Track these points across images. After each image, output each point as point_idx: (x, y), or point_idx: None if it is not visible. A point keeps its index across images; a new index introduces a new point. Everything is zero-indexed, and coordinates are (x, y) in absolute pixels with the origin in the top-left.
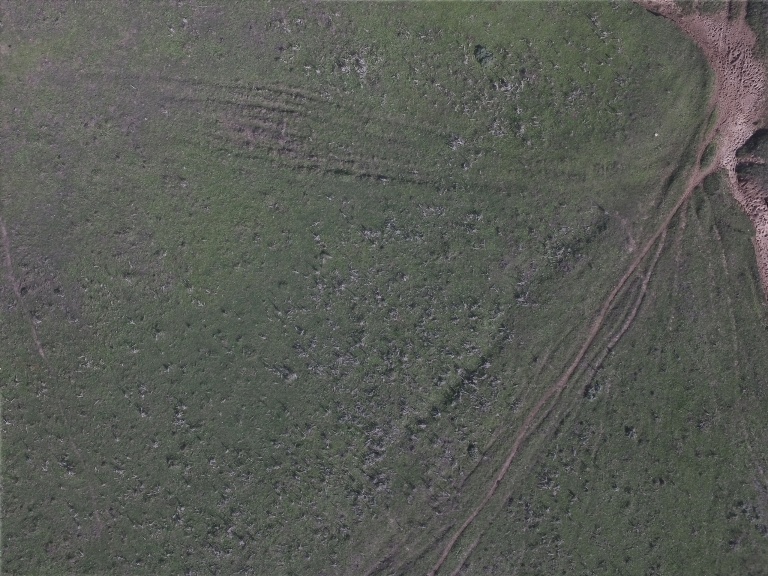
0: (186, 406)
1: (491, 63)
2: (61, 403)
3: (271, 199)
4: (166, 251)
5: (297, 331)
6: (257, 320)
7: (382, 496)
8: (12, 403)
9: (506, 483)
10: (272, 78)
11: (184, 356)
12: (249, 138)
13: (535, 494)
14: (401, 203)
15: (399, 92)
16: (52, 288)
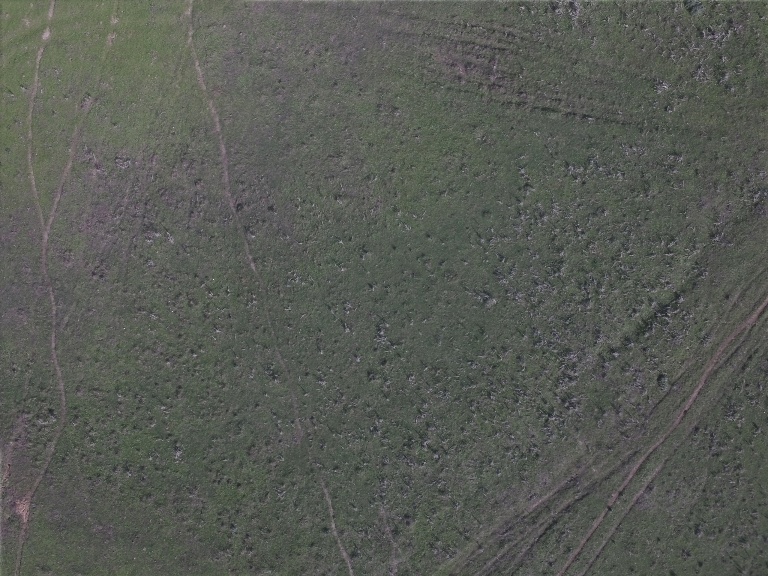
0: (389, 324)
1: (700, 12)
2: (269, 315)
3: (480, 132)
4: (376, 176)
5: (498, 258)
6: (460, 246)
7: (572, 419)
8: (223, 312)
9: (693, 413)
10: (487, 16)
11: (388, 277)
12: (461, 72)
13: (720, 425)
14: (604, 142)
15: (609, 35)
16: (266, 205)
